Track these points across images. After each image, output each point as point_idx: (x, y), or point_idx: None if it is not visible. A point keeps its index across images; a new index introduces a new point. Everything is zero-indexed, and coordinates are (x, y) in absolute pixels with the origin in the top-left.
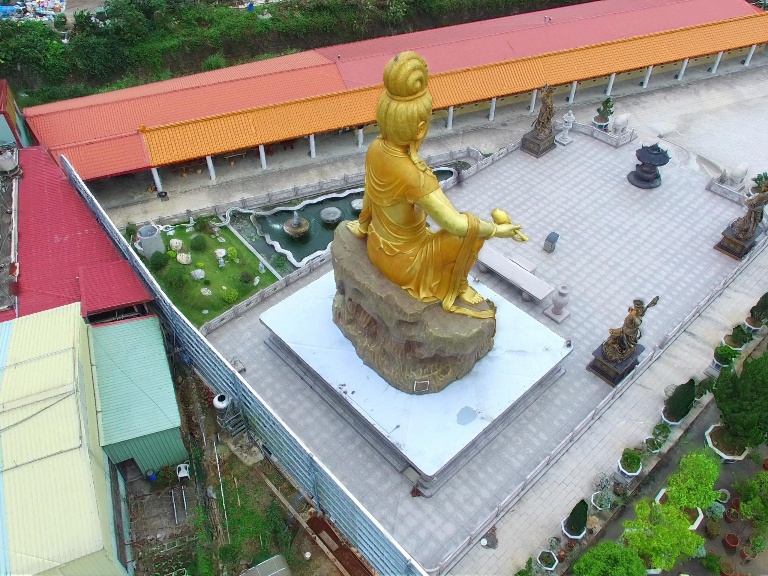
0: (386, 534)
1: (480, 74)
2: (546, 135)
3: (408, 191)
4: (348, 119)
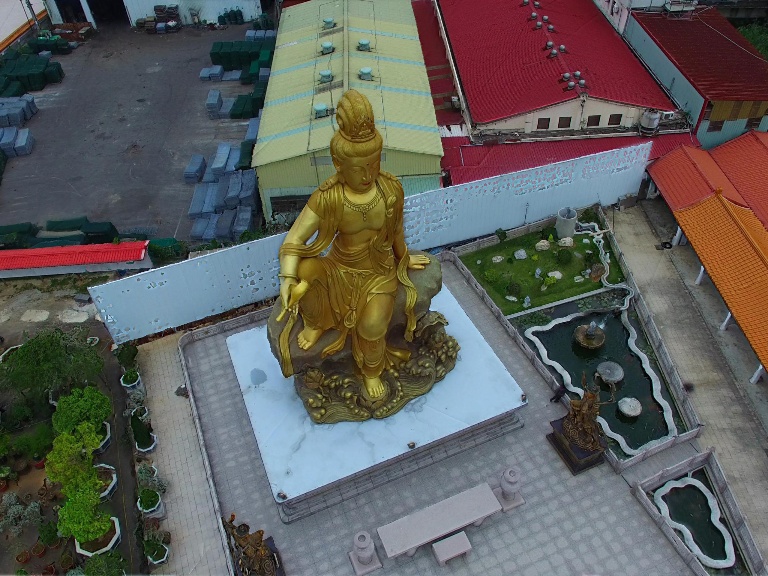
0: None
1: None
2: None
3: None
4: None
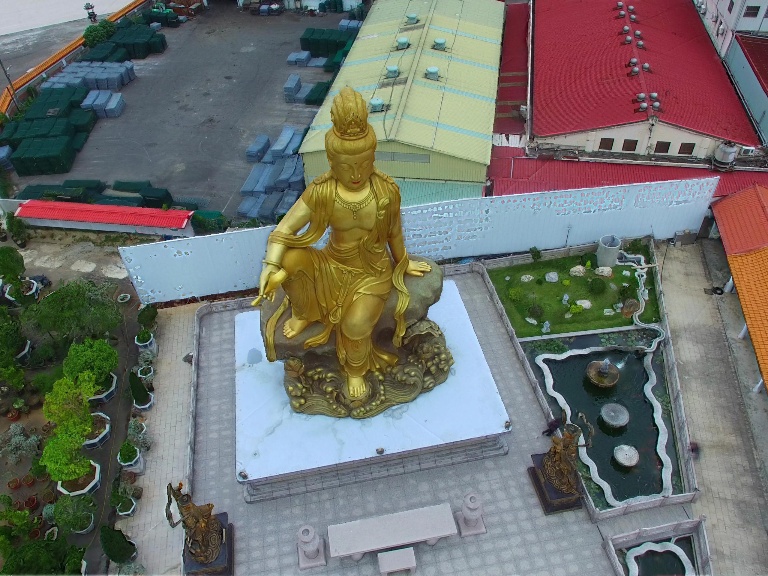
0: None
1: None
2: None
3: None
4: None
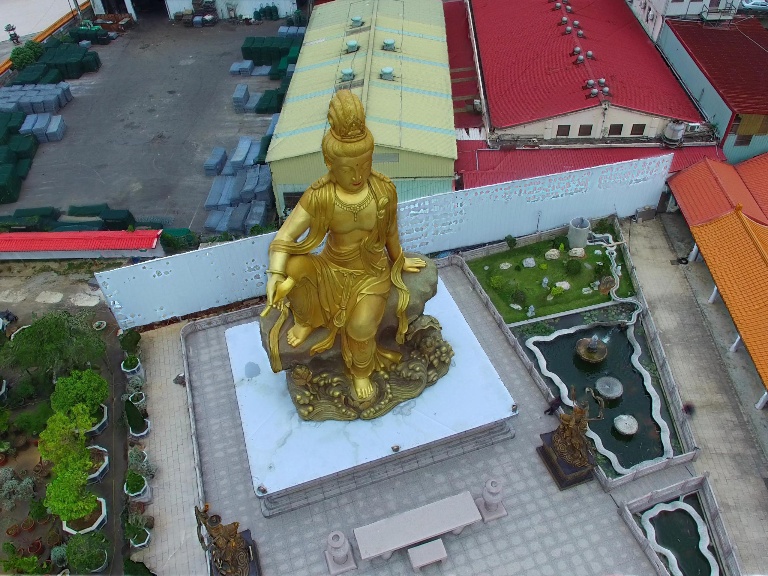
0: None
1: None
2: None
3: None
4: None
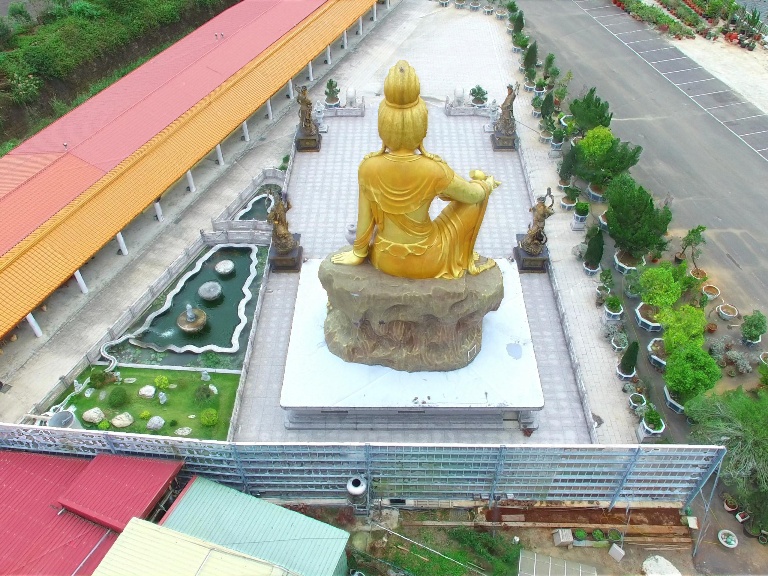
0: (609, 446)
1: (222, 102)
2: (315, 129)
3: (438, 185)
4: (145, 197)
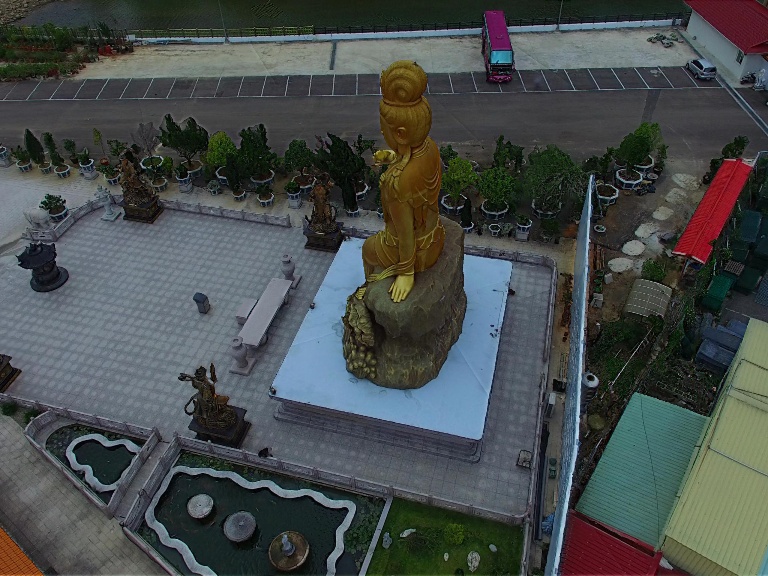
0: None
1: None
2: None
3: None
4: None
